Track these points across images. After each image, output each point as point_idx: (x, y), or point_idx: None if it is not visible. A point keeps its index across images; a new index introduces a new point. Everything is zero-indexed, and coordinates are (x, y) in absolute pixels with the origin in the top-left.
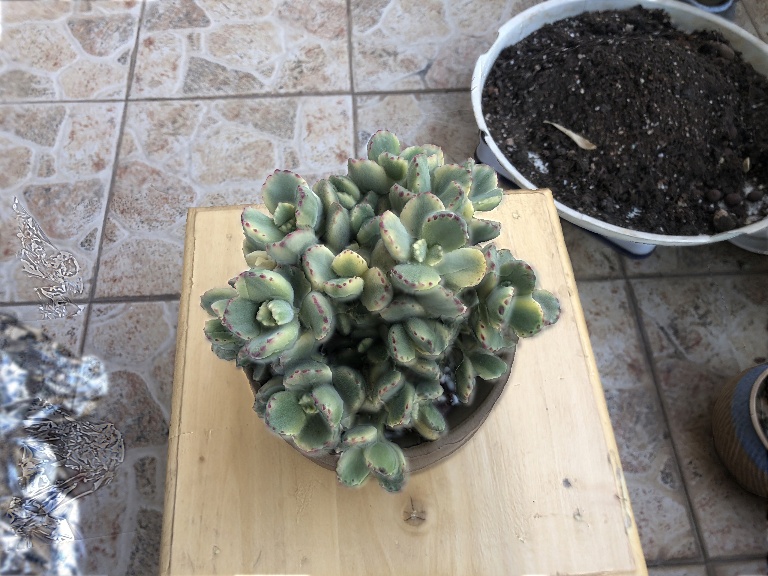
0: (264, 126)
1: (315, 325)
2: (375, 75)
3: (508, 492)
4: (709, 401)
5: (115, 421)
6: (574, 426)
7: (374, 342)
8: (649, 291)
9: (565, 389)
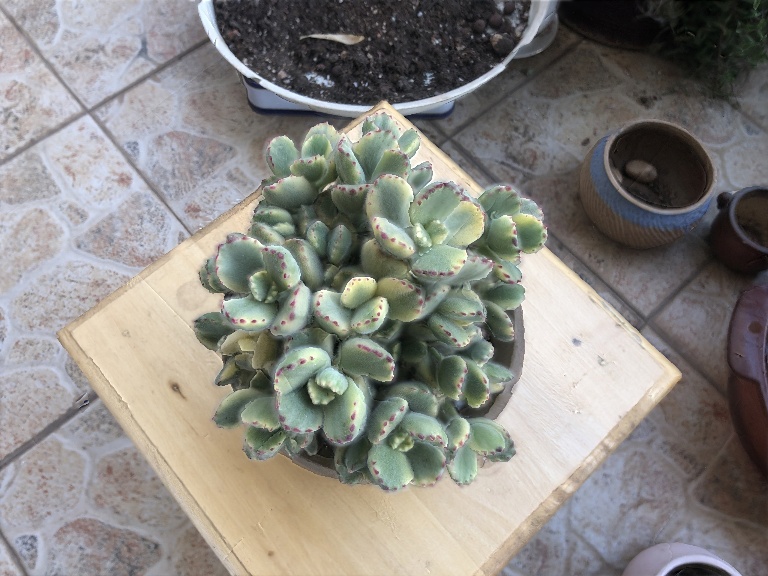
0: (20, 197)
1: (379, 371)
2: (97, 80)
3: (541, 383)
4: (572, 199)
5: (94, 575)
6: (550, 293)
7: (404, 344)
8: (473, 138)
9: (522, 267)
